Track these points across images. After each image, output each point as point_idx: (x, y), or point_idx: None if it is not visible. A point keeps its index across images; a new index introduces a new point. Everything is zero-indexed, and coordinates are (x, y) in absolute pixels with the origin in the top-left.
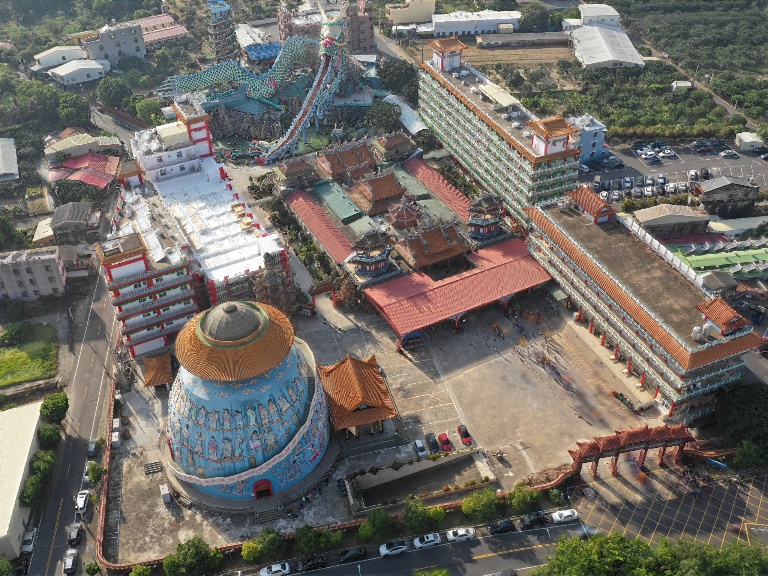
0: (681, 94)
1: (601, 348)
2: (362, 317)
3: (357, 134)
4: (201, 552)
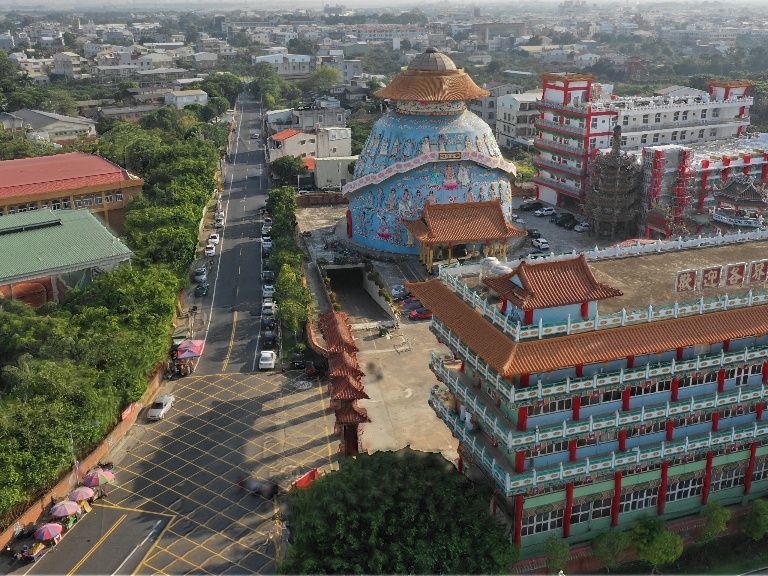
0: None
1: None
2: None
3: None
4: (278, 197)
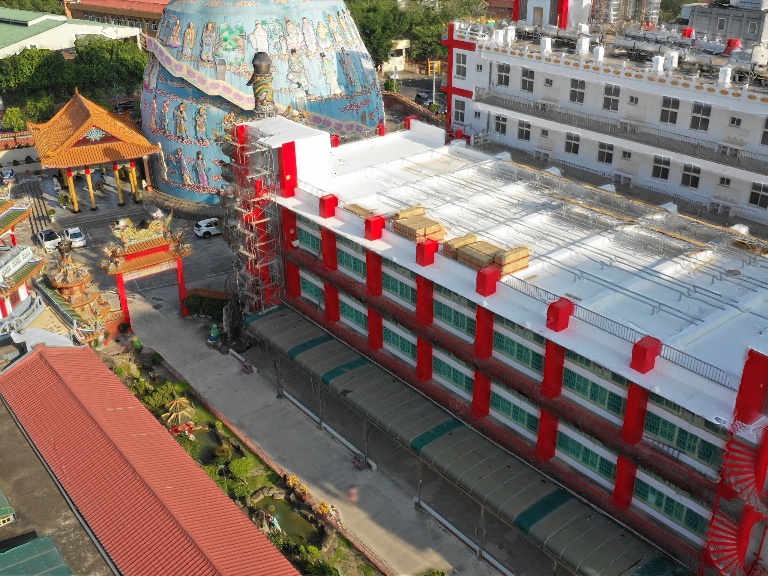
0: None
1: None
2: None
3: None
4: None
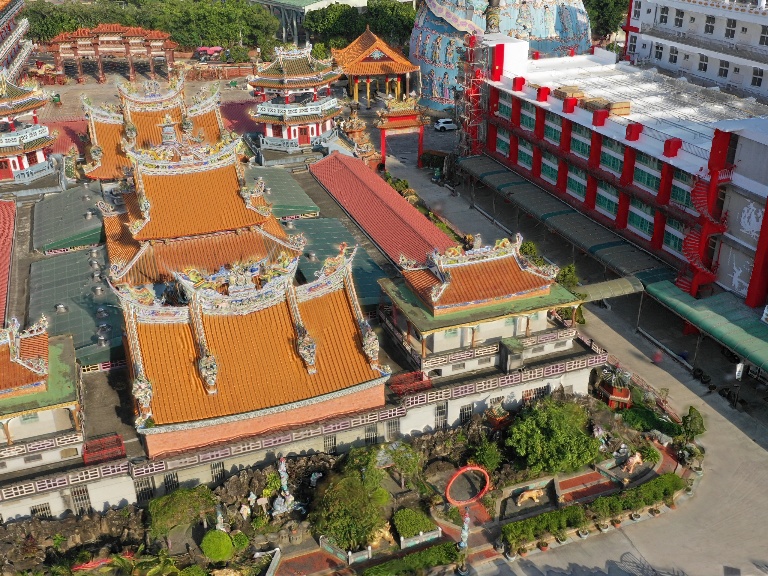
0: None
1: None
2: None
3: None
4: None
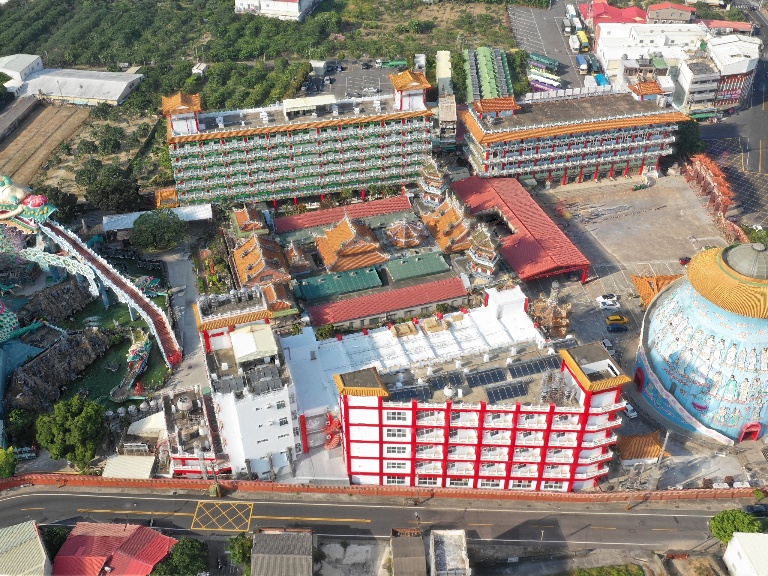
0: (220, 72)
1: (584, 184)
2: (531, 301)
3: (141, 274)
4: None
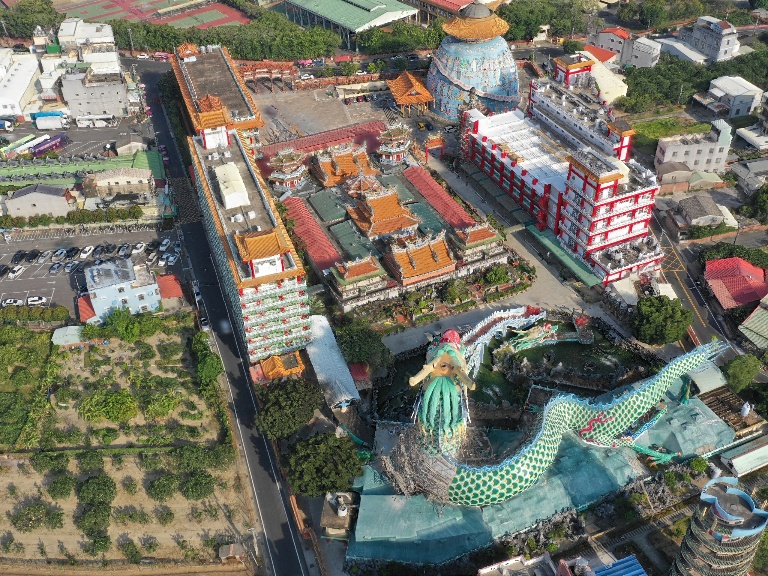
0: None
1: None
2: None
3: (405, 378)
4: None
